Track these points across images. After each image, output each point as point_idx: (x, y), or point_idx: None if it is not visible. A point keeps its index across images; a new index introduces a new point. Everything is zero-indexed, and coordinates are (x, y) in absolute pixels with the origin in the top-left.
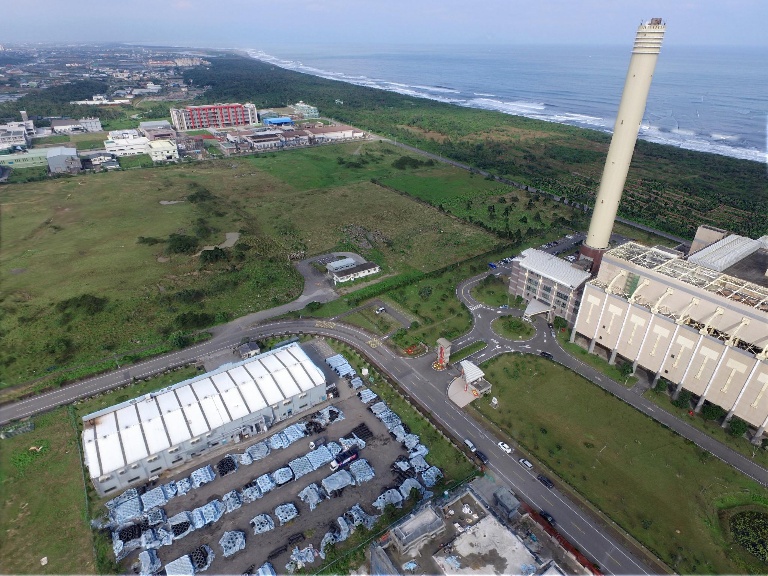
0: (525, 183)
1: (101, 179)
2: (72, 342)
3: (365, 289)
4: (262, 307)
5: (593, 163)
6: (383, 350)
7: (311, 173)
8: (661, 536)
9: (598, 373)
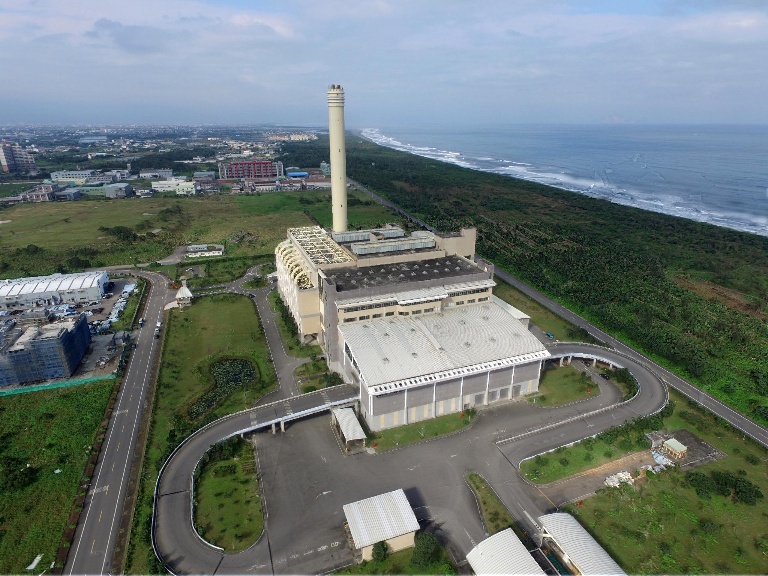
0: (419, 218)
1: (126, 201)
2: (10, 265)
3: None
4: (128, 263)
5: (513, 210)
6: (163, 286)
7: (268, 205)
8: (177, 359)
9: (268, 306)
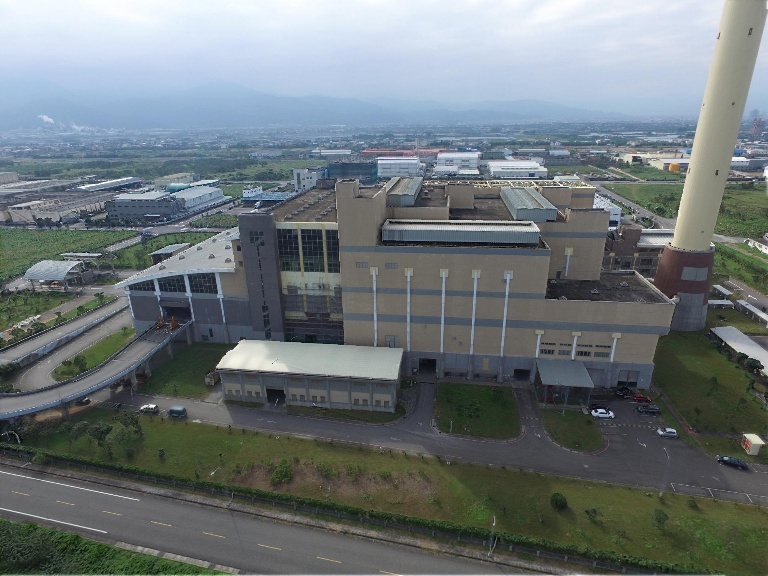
0: None
1: None
2: None
3: (726, 247)
4: None
5: None
6: None
7: None
8: None
9: None
